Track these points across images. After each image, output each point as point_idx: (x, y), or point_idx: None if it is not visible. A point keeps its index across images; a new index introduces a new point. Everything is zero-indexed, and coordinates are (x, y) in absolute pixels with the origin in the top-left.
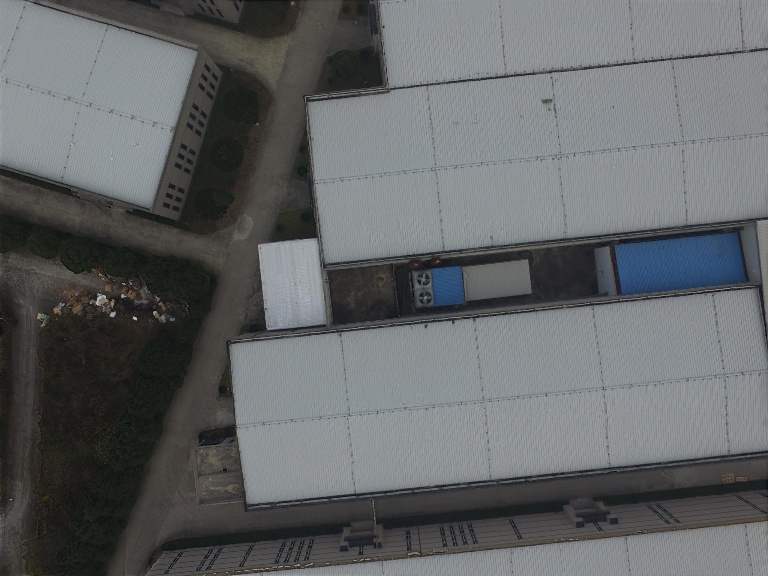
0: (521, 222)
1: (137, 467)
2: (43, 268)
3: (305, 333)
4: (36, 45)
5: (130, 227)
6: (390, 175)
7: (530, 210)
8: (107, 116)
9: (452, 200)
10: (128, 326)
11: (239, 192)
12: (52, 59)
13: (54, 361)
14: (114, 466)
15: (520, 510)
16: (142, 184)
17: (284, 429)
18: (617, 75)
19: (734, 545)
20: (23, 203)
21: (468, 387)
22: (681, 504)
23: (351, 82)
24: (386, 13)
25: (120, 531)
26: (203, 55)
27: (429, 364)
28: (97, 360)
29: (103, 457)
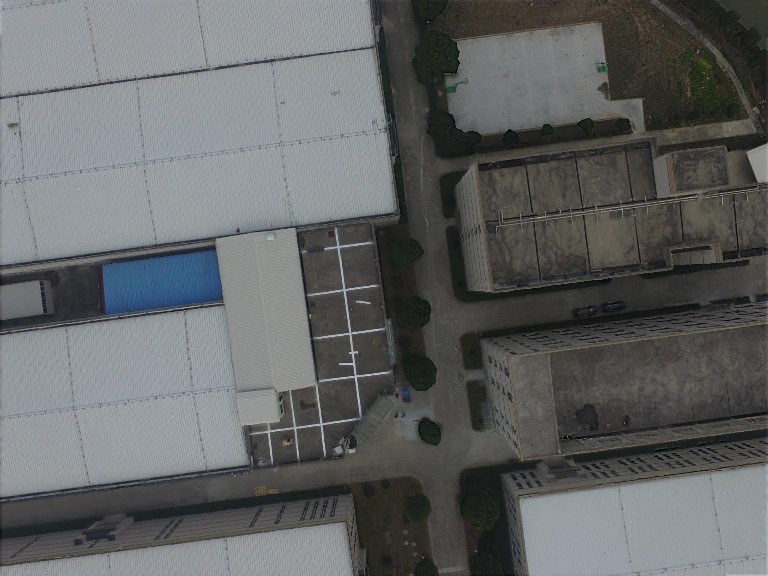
0: None
1: None
2: None
3: None
4: None
5: None
6: None
7: None
8: None
9: None
10: None
11: None
12: None
13: None
14: None
15: (54, 527)
16: None
17: None
18: (83, 97)
19: (214, 559)
20: None
21: None
22: (201, 518)
23: None
24: None
25: None
26: None
27: None
28: None
29: None
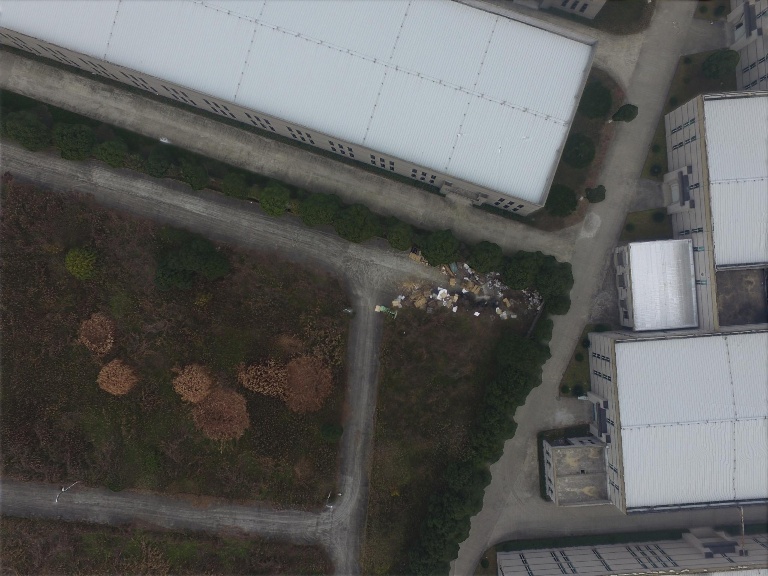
0: None
1: None
2: (383, 260)
3: (691, 335)
4: (426, 33)
5: (475, 221)
6: None
7: None
8: (498, 108)
9: None
10: (468, 321)
11: None
12: (442, 48)
13: (401, 355)
14: (479, 464)
15: None
16: (529, 178)
17: (669, 432)
18: None
19: None
20: (365, 193)
21: None
22: None
23: (712, 83)
24: None
25: None
26: None
27: None
28: (436, 355)
29: (462, 454)
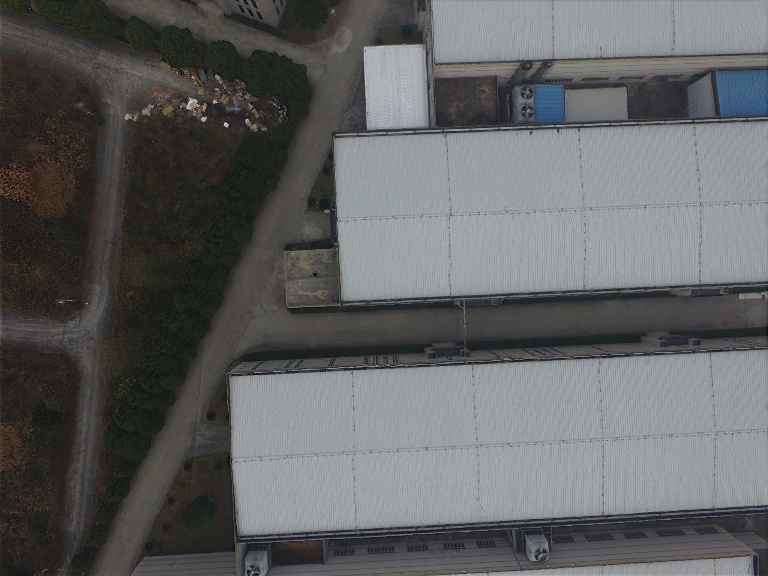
0: (633, 32)
1: (225, 268)
2: (133, 68)
3: (411, 131)
4: None
5: (226, 31)
6: None
7: (641, 24)
8: None
9: (565, 7)
10: (218, 133)
11: (340, 3)
12: None
13: (143, 159)
14: (205, 259)
15: (599, 339)
16: None
17: (385, 225)
18: None
19: None
20: None
21: (569, 194)
22: (756, 338)
23: None
24: None
25: (203, 333)
26: None
27: (532, 170)
28: (185, 165)
29: (193, 253)
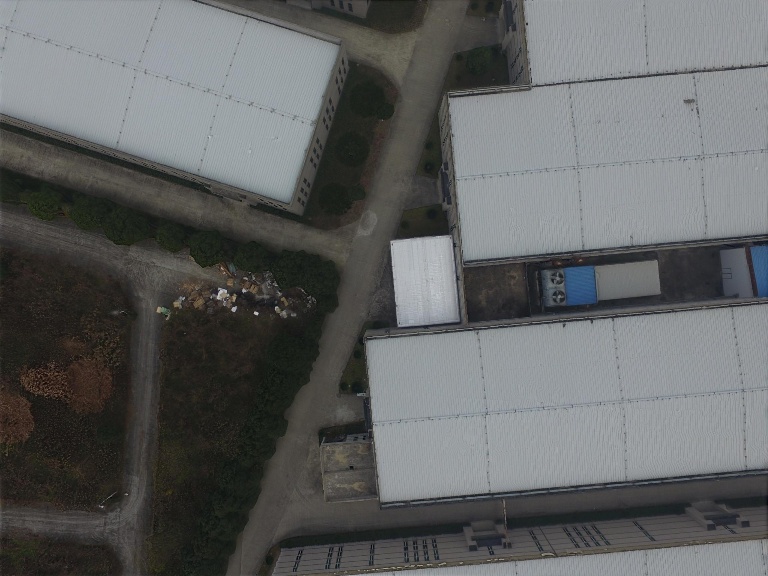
0: (664, 222)
1: (261, 463)
2: (163, 261)
3: (442, 330)
4: (175, 36)
5: (253, 221)
6: (532, 173)
7: (671, 210)
8: (247, 109)
9: (593, 199)
10: (249, 321)
11: None
12: (191, 50)
13: (177, 355)
14: (243, 462)
15: (642, 512)
16: (280, 178)
17: (421, 427)
18: (759, 76)
19: None
20: (144, 195)
21: (607, 387)
22: None
23: (481, 79)
24: (530, 10)
25: (242, 528)
26: (343, 49)
27: (567, 363)
28: (217, 355)
29: (230, 453)
